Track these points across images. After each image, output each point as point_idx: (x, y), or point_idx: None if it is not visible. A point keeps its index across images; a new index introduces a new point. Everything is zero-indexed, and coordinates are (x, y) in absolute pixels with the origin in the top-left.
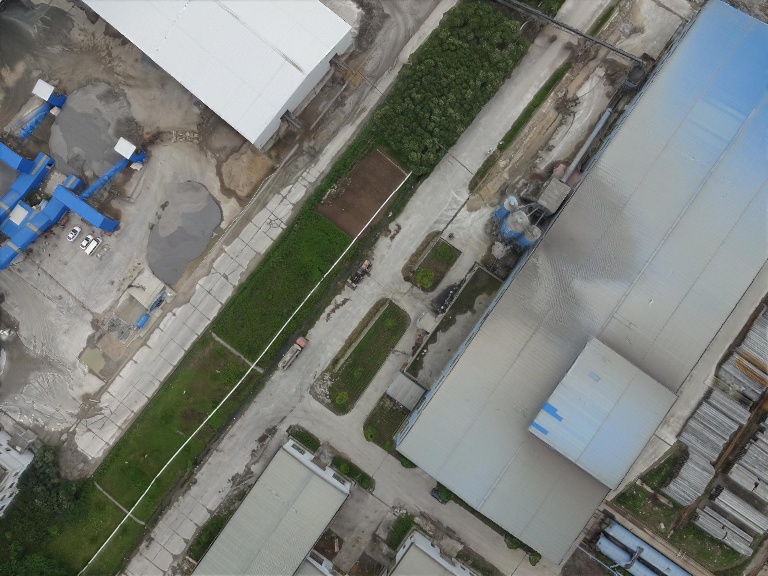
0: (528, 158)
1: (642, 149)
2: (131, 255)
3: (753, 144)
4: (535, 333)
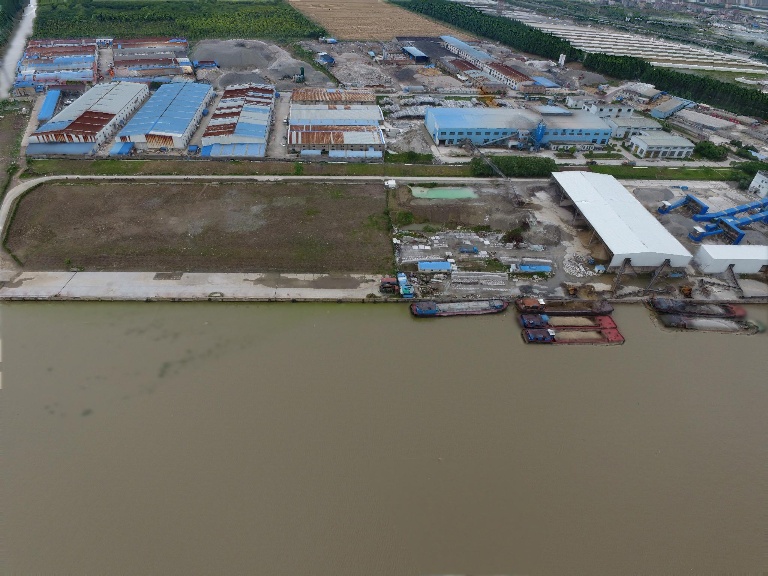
0: (514, 153)
1: (492, 124)
2: (681, 200)
3: None
4: (555, 122)
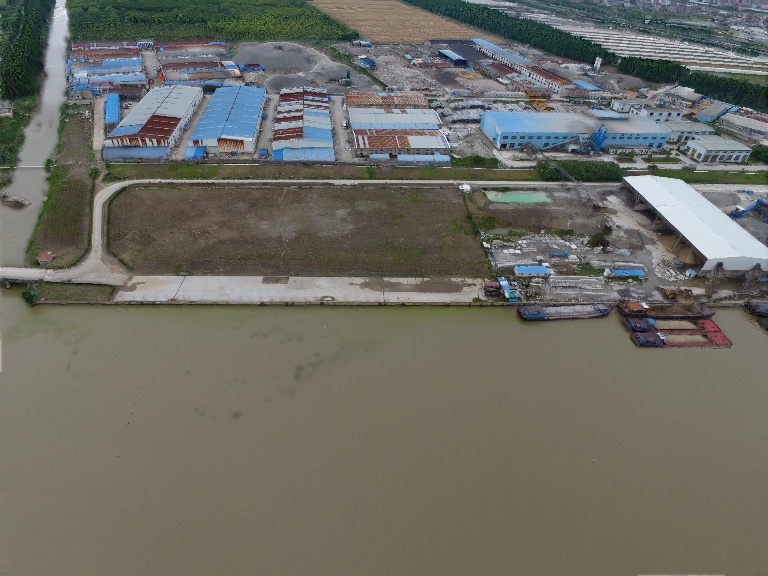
0: (574, 157)
1: (552, 128)
2: None
3: (523, 117)
4: None
